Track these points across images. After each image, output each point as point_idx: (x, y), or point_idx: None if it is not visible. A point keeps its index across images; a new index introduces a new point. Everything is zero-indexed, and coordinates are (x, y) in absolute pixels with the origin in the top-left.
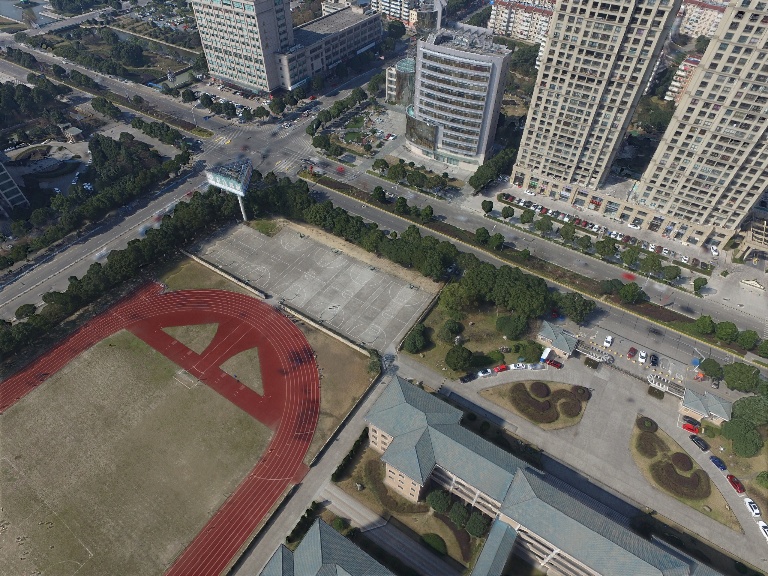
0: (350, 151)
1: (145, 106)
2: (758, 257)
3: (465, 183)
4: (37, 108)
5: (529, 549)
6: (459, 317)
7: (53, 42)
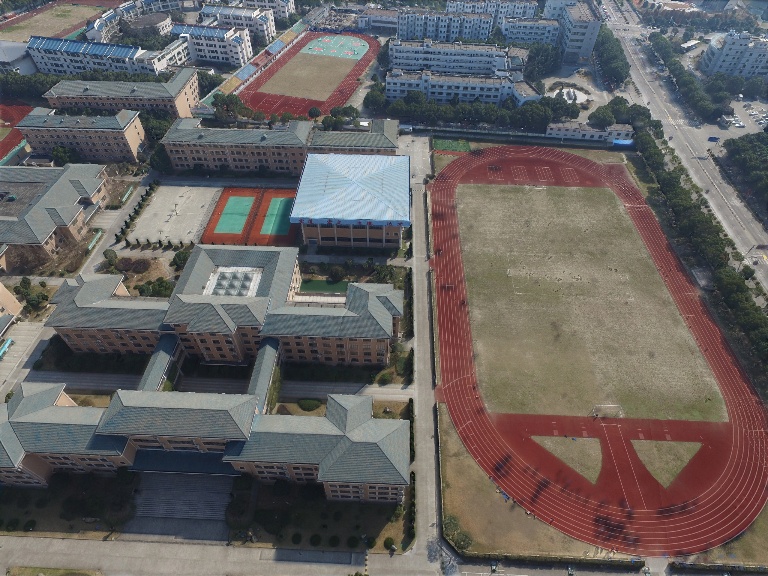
0: None
1: None
2: None
3: None
4: None
5: None
6: None
7: None
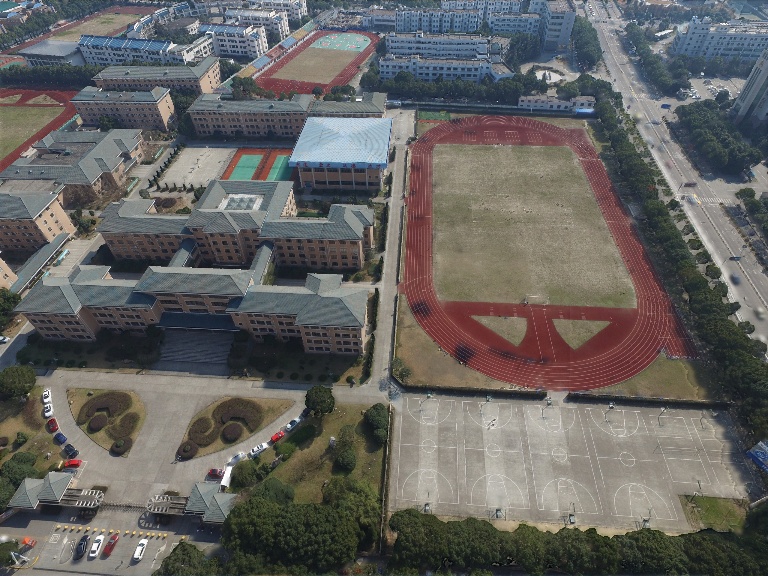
0: None
1: None
2: None
3: None
4: None
5: None
6: None
7: None
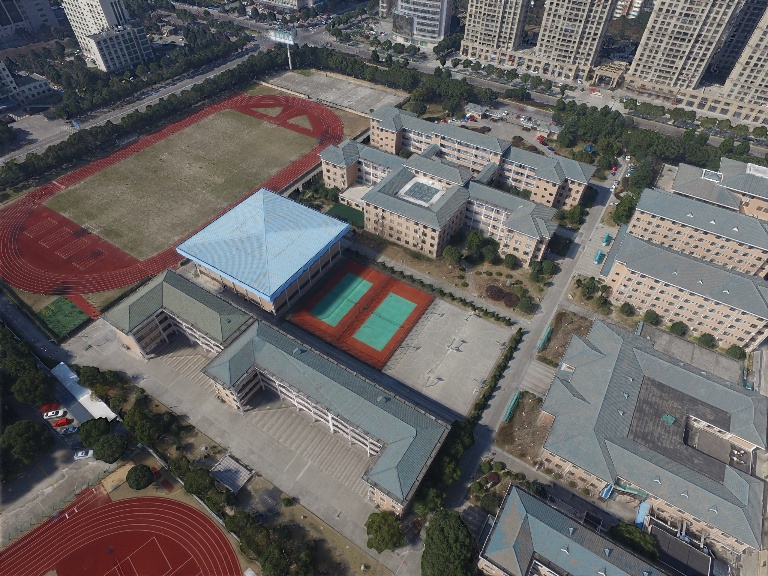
0: (355, 40)
1: (211, 18)
2: (605, 84)
3: (431, 55)
4: None
5: None
6: None
7: None
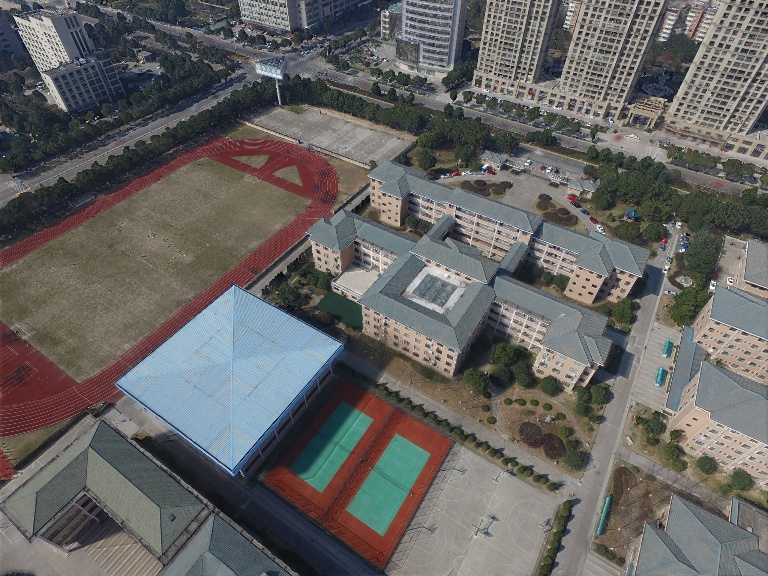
0: (354, 68)
1: (194, 41)
2: (641, 123)
3: (439, 86)
4: (111, 41)
5: (462, 233)
6: (430, 151)
7: (109, 1)
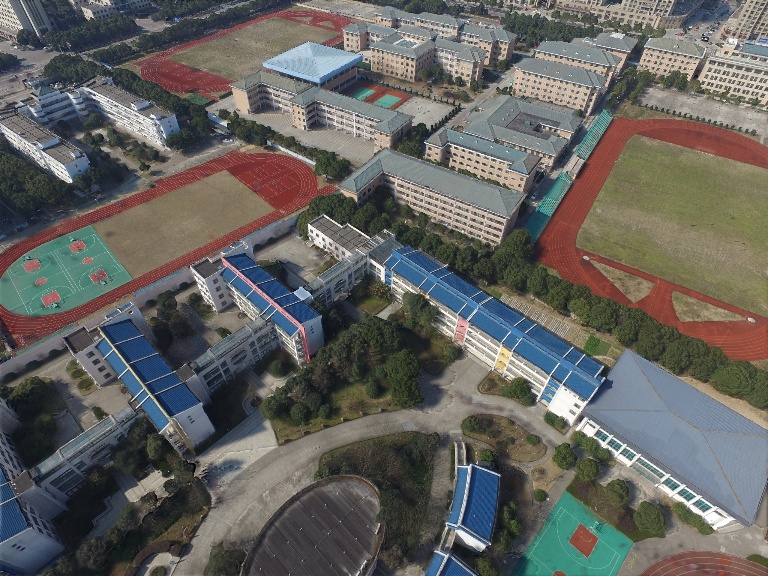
0: None
1: None
2: (543, 6)
3: None
4: None
5: None
6: None
7: None
